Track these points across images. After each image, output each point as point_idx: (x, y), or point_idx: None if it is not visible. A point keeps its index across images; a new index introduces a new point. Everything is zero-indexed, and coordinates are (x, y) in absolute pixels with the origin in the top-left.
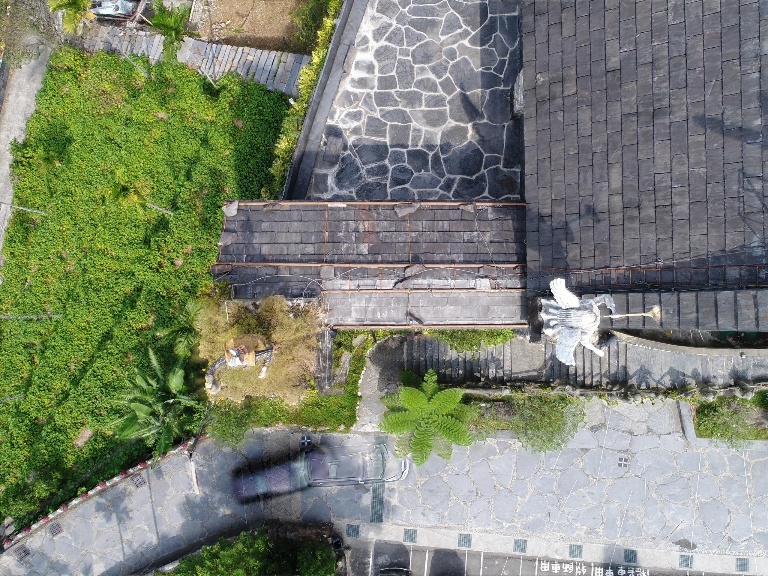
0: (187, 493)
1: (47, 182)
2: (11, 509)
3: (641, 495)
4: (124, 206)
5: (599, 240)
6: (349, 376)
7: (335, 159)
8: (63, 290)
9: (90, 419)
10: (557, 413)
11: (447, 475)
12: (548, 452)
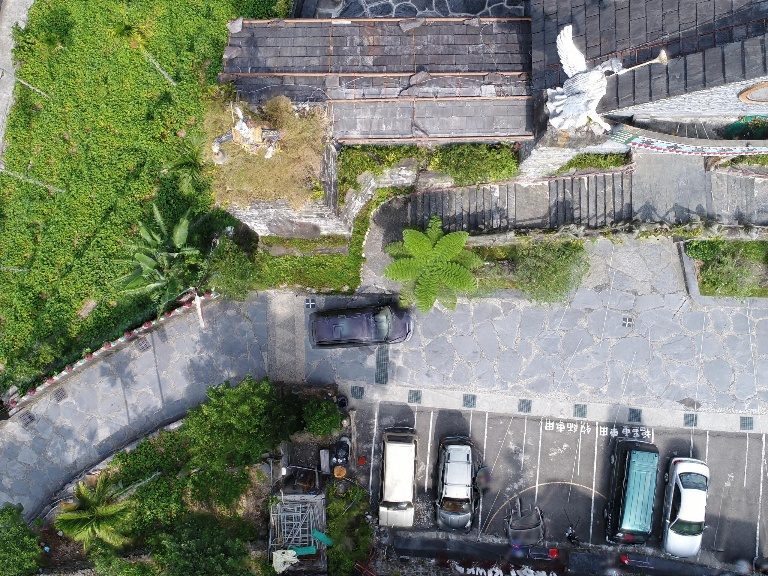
0: (192, 356)
1: (49, 68)
2: (16, 371)
3: (645, 354)
4: (126, 84)
5: (605, 27)
6: (353, 237)
7: None
8: (66, 171)
9: (94, 288)
10: (561, 262)
11: (451, 336)
12: (552, 313)
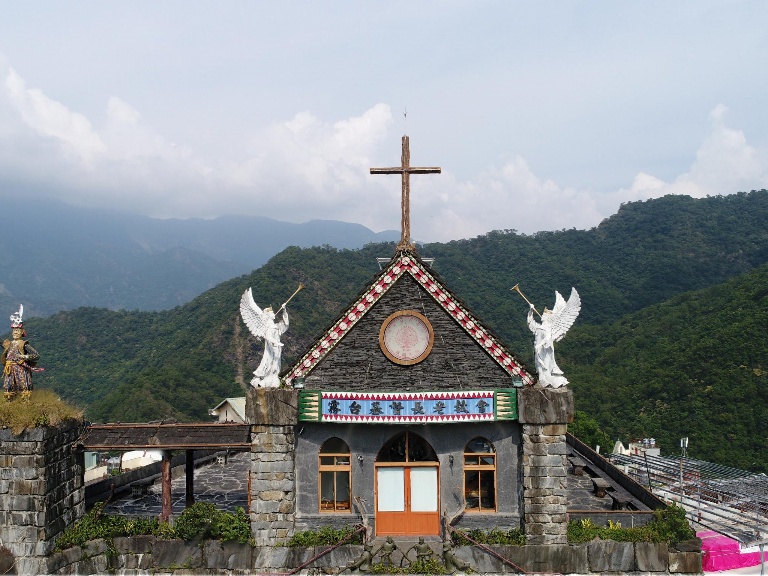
0: None
1: None
2: None
3: None
4: None
5: None
6: None
7: (139, 484)
8: None
9: None
10: None
11: None
12: None
